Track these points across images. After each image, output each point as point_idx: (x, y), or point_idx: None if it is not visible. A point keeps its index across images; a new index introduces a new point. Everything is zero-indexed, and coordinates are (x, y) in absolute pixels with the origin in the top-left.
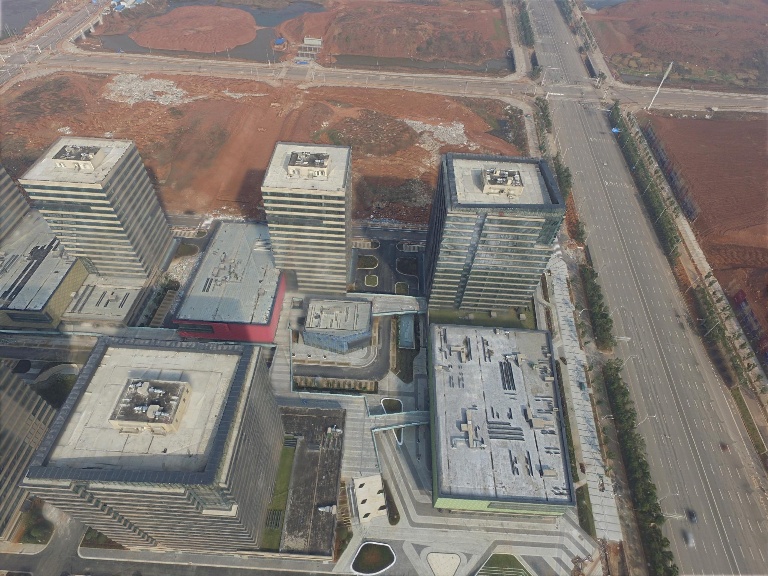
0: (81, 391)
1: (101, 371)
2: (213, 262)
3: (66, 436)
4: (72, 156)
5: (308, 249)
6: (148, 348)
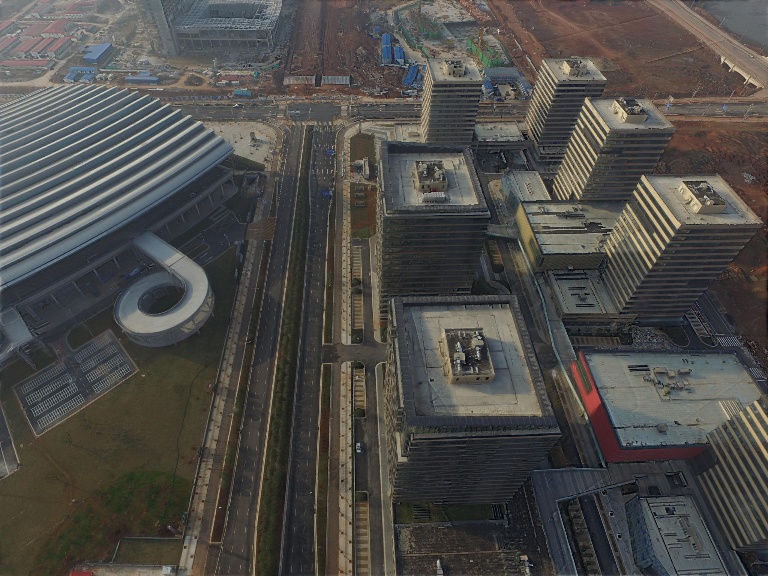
0: (464, 302)
1: (486, 308)
2: (672, 363)
3: (428, 308)
4: (698, 191)
5: (760, 468)
6: (519, 332)
